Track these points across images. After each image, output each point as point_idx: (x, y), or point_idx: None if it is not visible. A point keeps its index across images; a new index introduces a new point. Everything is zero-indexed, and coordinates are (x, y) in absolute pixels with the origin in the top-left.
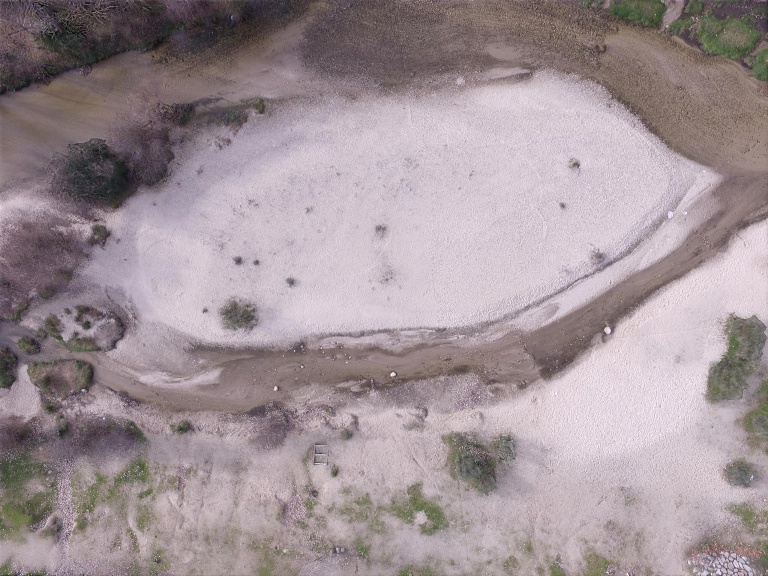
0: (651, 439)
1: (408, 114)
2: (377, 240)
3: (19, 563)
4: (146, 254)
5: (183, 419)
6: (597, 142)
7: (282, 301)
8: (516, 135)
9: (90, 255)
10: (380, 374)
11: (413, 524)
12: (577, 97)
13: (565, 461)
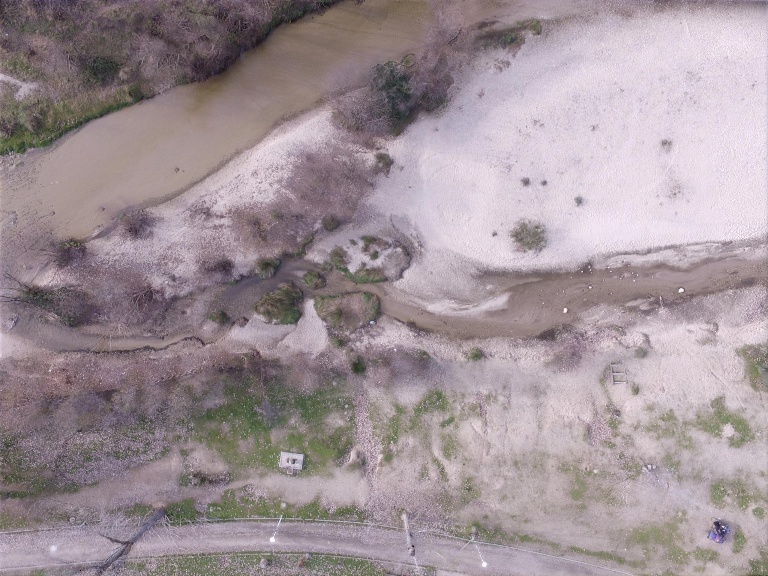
0: None
1: (686, 28)
2: (663, 155)
3: (328, 499)
4: (431, 180)
5: (473, 346)
6: None
7: (570, 221)
8: None
9: (375, 184)
10: (668, 291)
11: (721, 437)
12: None
13: None
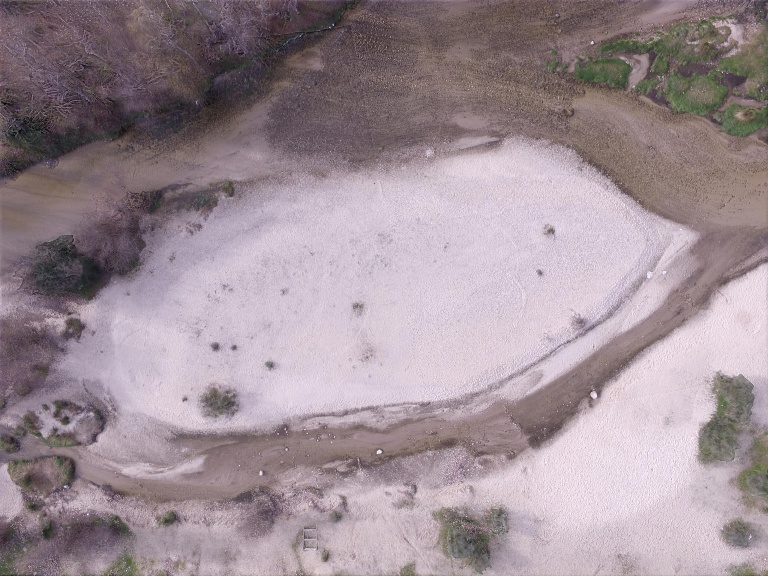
0: (645, 503)
1: (379, 189)
2: (355, 318)
3: None
4: (122, 345)
5: (168, 510)
6: (571, 207)
7: (262, 385)
8: (489, 204)
9: (66, 349)
10: (366, 452)
11: None
12: (548, 162)
13: (559, 531)
